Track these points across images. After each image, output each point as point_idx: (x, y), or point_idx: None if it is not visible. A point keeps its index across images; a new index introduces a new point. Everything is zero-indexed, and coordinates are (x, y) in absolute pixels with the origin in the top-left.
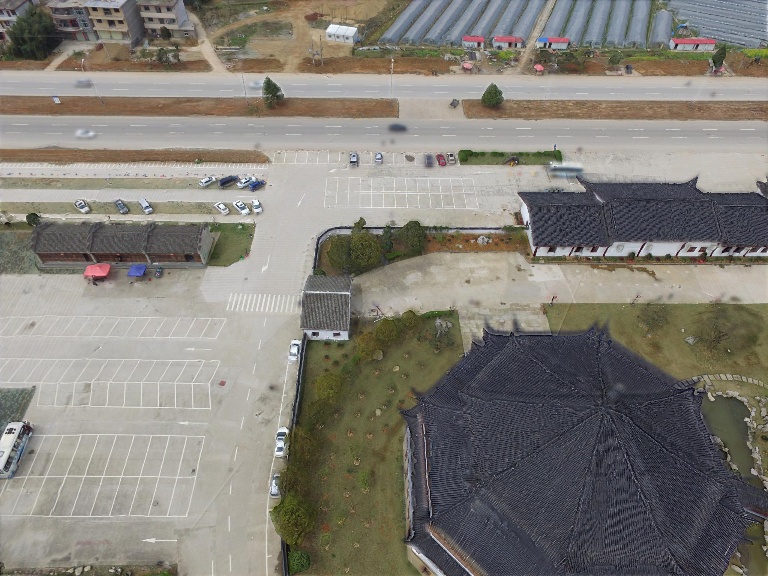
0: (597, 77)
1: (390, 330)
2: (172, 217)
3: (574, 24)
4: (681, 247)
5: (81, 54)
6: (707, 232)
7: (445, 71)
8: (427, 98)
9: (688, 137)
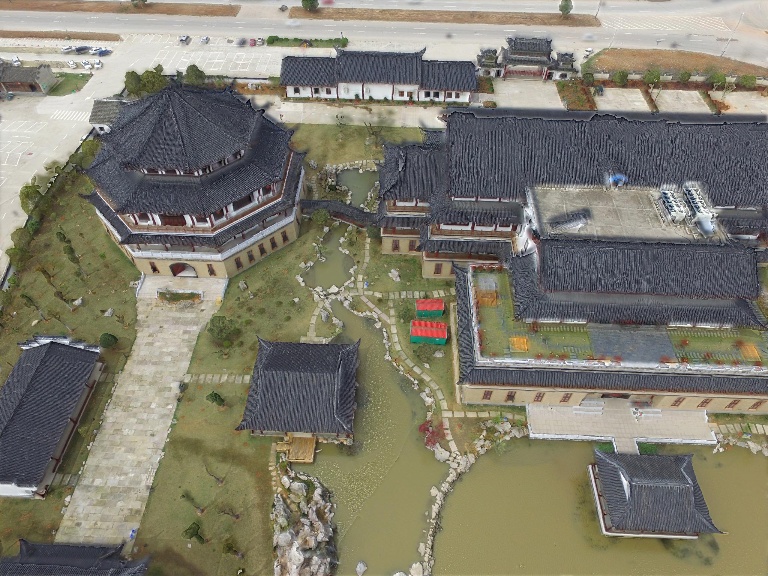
0: None
1: None
2: None
3: None
4: (392, 91)
5: None
6: (407, 78)
7: None
8: (265, 5)
9: (458, 34)
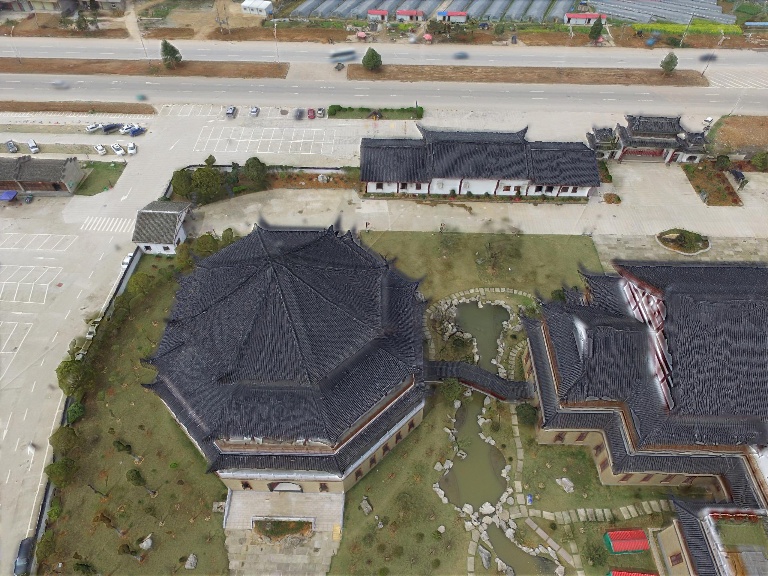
0: (483, 46)
1: (205, 242)
2: (54, 156)
3: (479, 0)
4: (496, 186)
5: (14, 22)
6: (516, 171)
7: (342, 40)
8: (317, 62)
9: (548, 98)
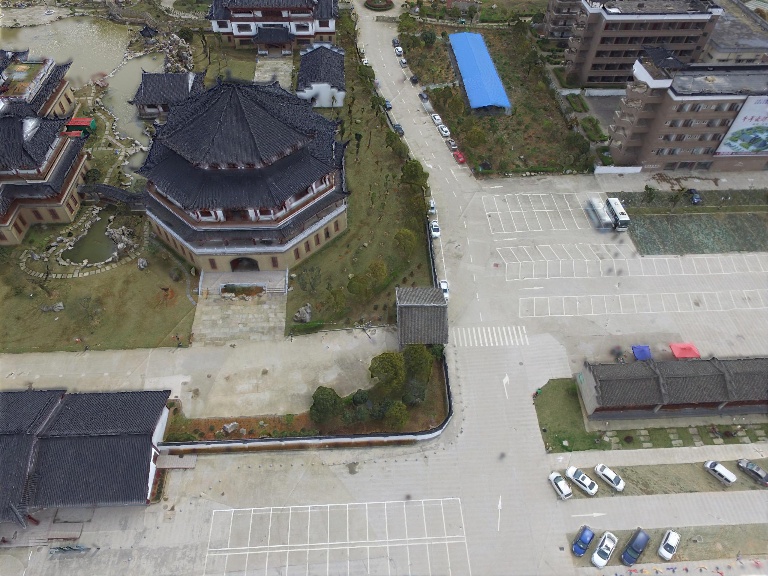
0: None
1: (357, 277)
2: (669, 455)
3: None
4: None
5: None
6: None
7: None
8: None
9: None
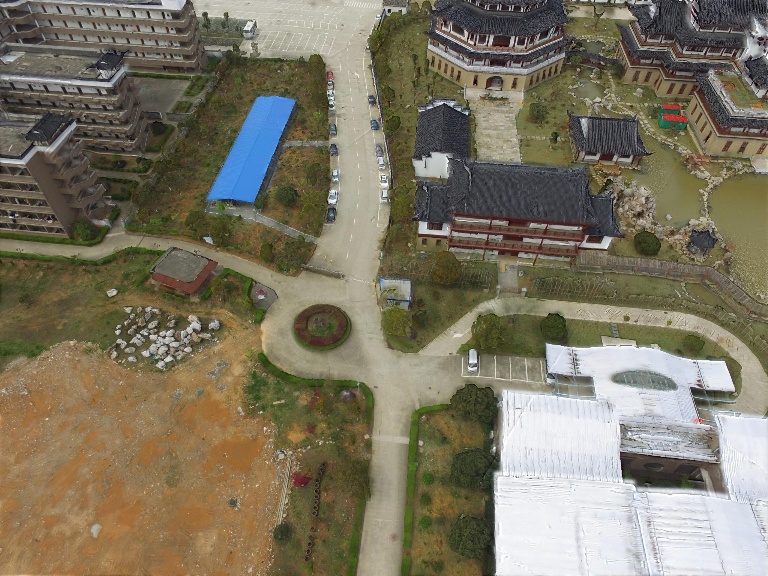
0: None
1: (427, 3)
2: None
3: None
4: None
5: None
6: None
7: None
8: None
9: None
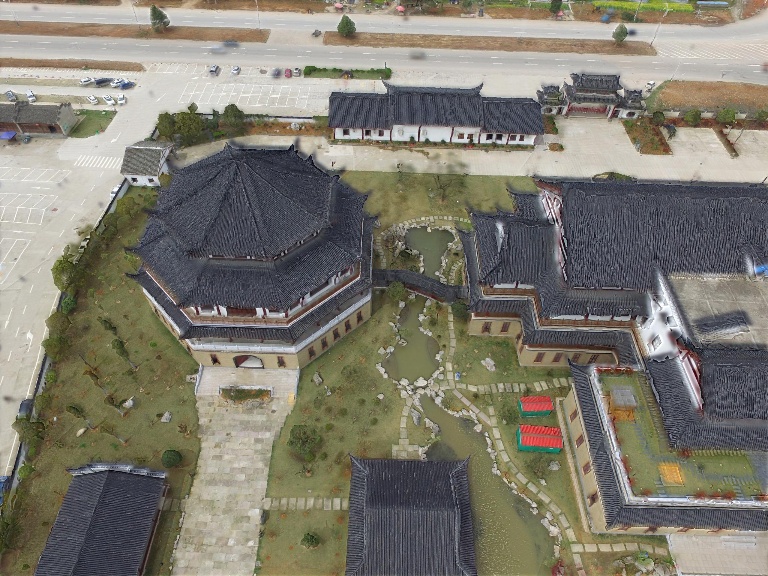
0: (452, 18)
1: None
2: (50, 104)
3: None
4: (451, 133)
5: None
6: (469, 120)
7: (320, 10)
8: (296, 29)
9: (508, 63)
